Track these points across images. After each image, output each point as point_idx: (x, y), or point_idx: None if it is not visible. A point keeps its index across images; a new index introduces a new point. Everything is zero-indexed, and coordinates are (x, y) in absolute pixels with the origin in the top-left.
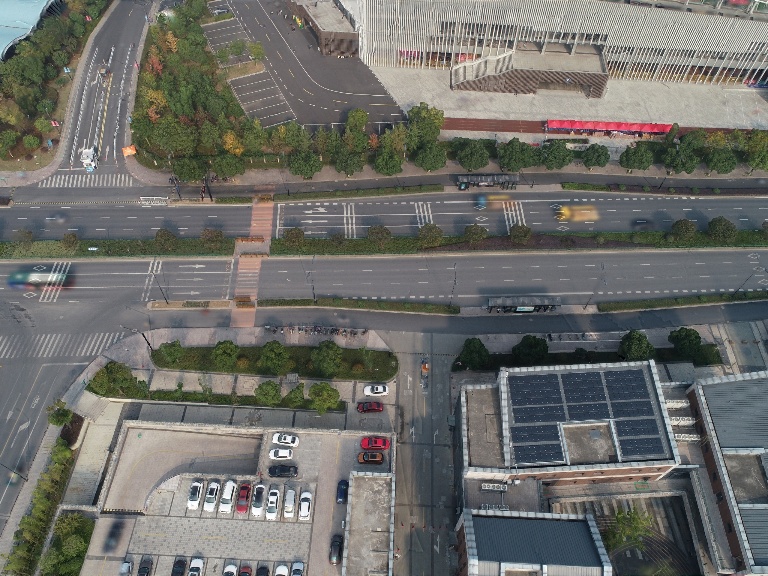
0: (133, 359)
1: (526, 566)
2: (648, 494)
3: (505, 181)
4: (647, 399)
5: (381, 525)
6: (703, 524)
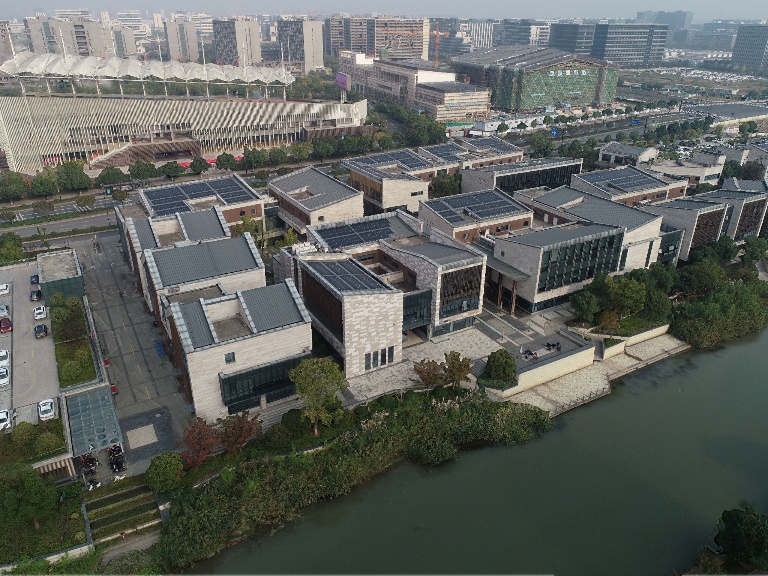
0: None
1: (166, 218)
2: (261, 235)
3: (139, 182)
4: (237, 186)
5: (68, 265)
6: (290, 225)
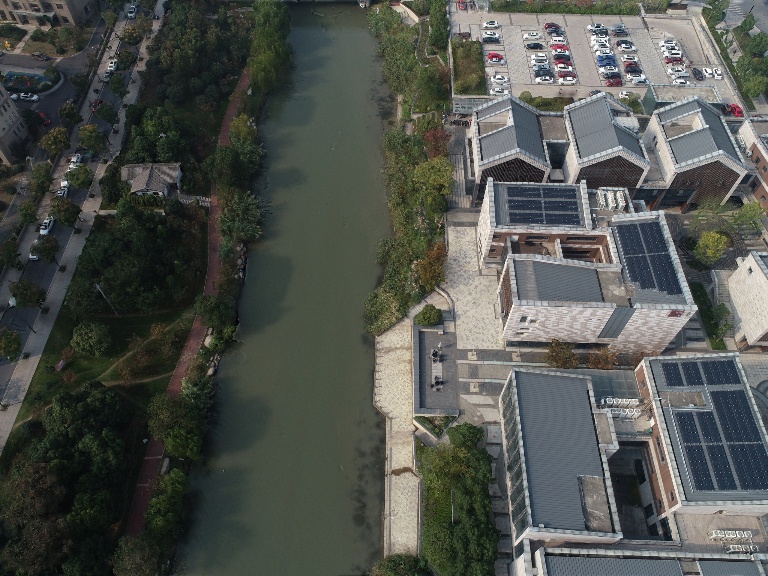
0: (732, 21)
1: (703, 121)
2: None
3: None
4: None
5: None
6: None
